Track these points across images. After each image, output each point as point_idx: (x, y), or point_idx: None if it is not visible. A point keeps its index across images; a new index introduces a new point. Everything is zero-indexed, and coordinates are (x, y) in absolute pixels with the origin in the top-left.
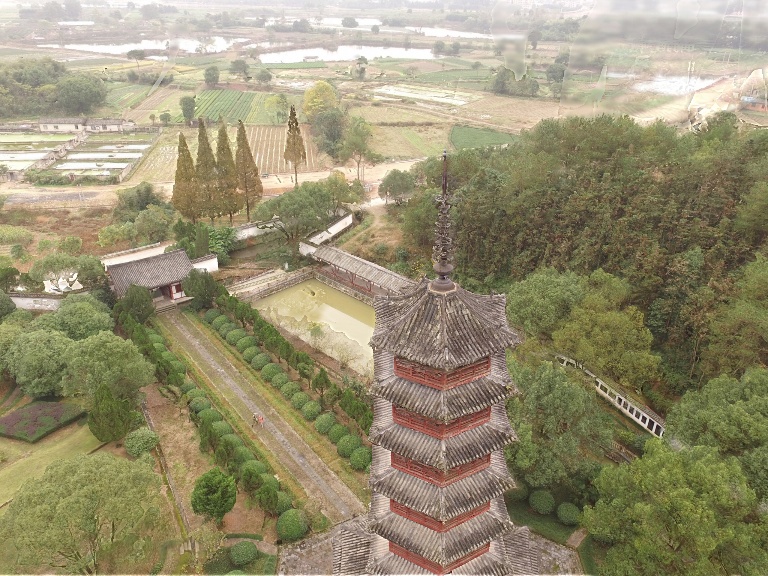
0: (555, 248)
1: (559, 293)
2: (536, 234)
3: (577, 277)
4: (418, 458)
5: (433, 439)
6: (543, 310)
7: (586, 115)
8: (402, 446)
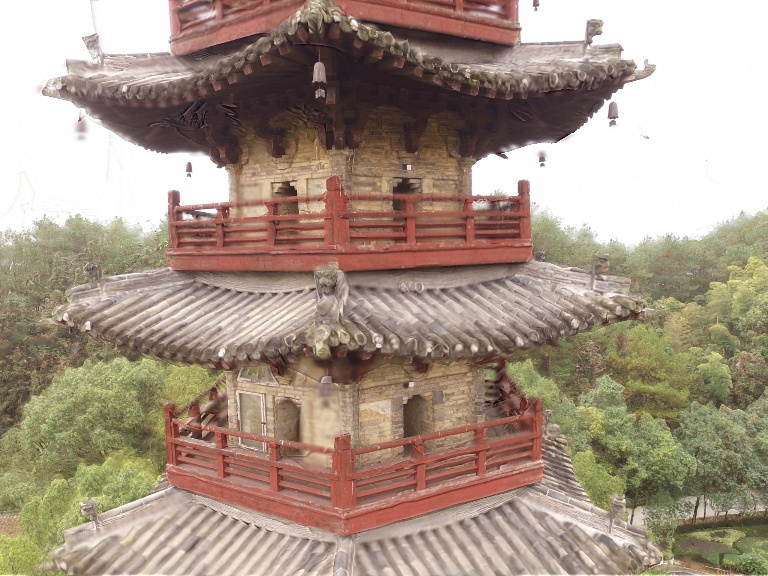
0: (45, 376)
1: (133, 372)
2: (1, 368)
3: (133, 362)
4: (536, 327)
5: (489, 285)
6: (120, 403)
7: (13, 226)
8: (443, 328)
